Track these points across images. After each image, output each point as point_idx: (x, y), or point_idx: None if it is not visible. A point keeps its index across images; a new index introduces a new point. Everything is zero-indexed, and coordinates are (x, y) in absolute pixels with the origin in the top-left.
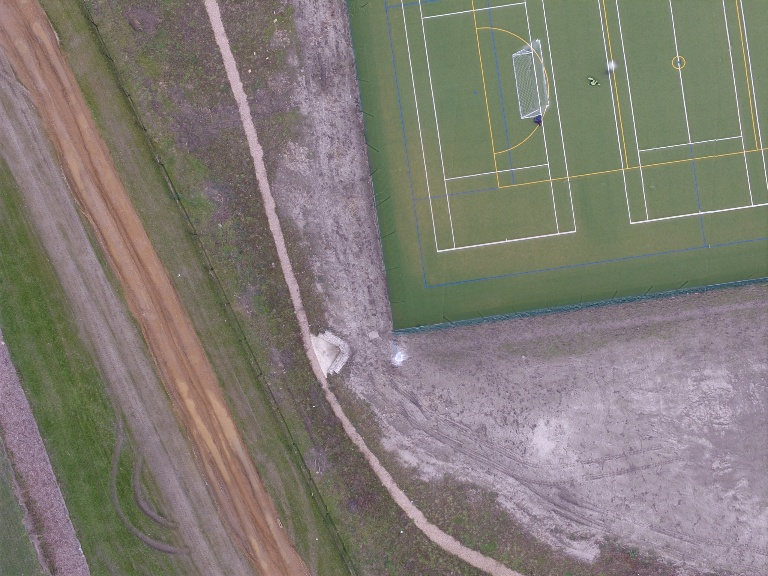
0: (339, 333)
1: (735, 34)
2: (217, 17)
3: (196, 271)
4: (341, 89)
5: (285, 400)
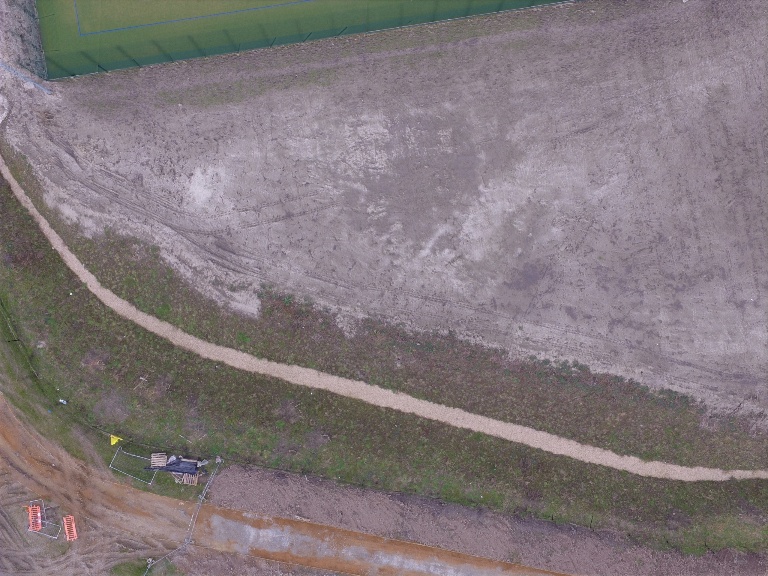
0: None
1: None
2: None
3: None
4: None
5: None
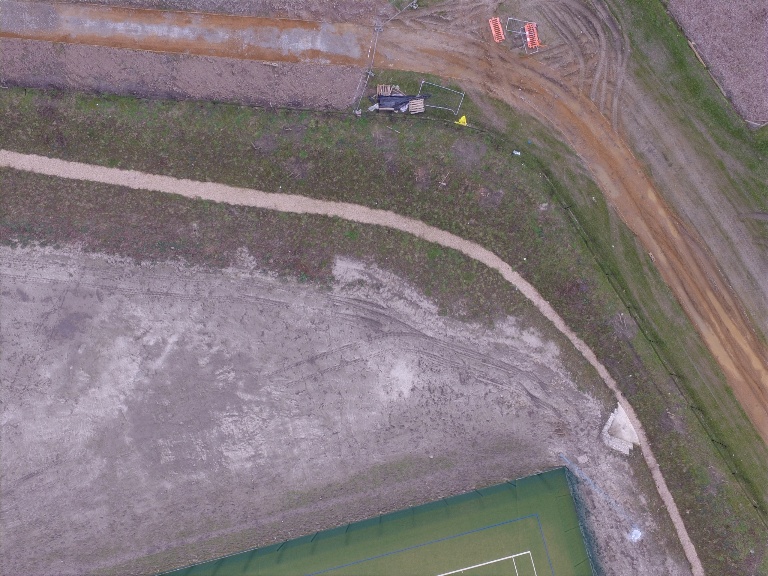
0: (616, 455)
1: None
2: None
3: None
4: None
5: (664, 383)
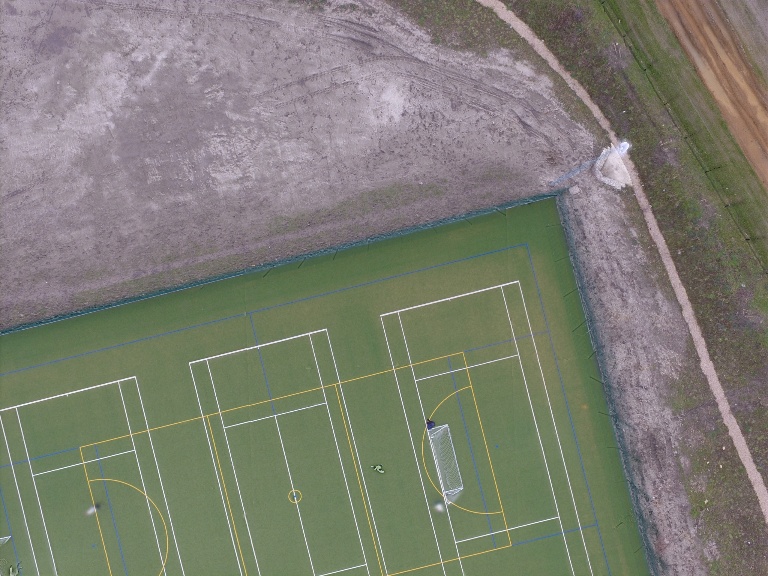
0: (608, 189)
1: (242, 530)
2: (763, 501)
3: (763, 236)
4: (634, 437)
5: (658, 114)
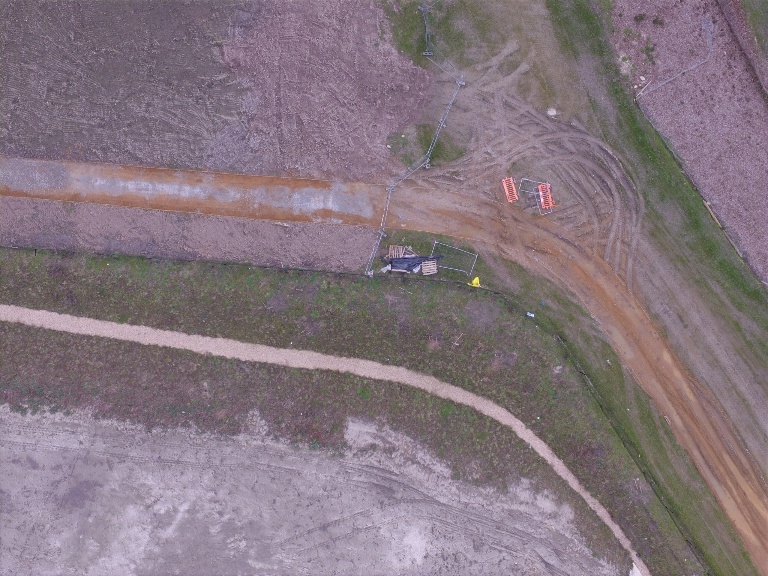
0: None
1: None
2: None
3: None
4: None
5: (680, 549)
